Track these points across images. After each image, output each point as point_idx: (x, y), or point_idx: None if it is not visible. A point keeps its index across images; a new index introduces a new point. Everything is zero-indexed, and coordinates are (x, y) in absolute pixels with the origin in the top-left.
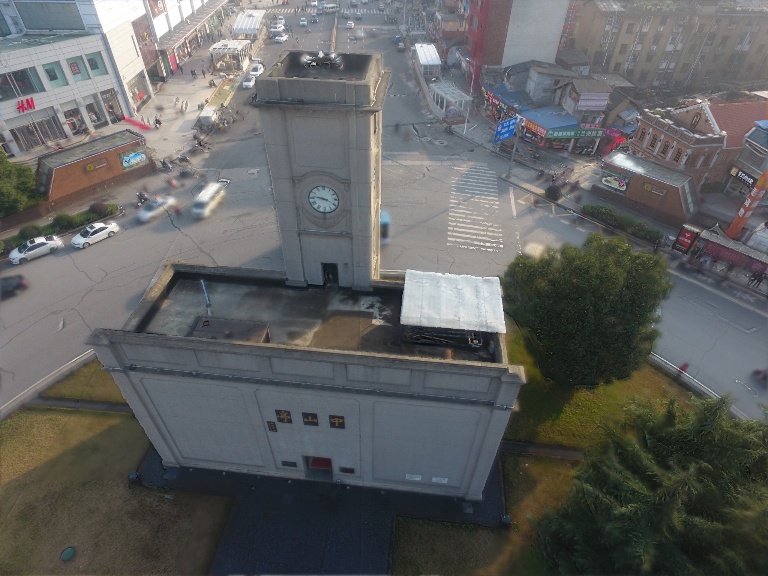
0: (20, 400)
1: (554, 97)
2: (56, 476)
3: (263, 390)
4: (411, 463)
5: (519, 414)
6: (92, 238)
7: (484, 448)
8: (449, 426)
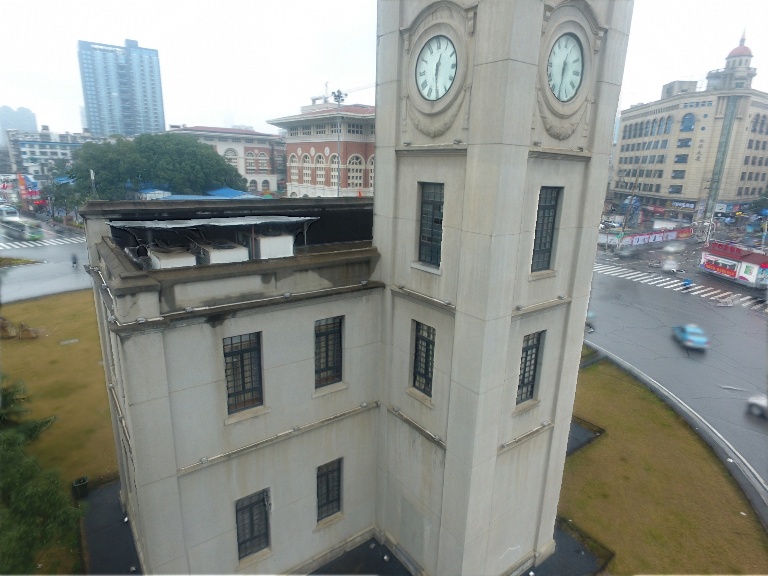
0: None
1: None
2: None
3: None
4: None
5: None
6: None
7: None
8: None
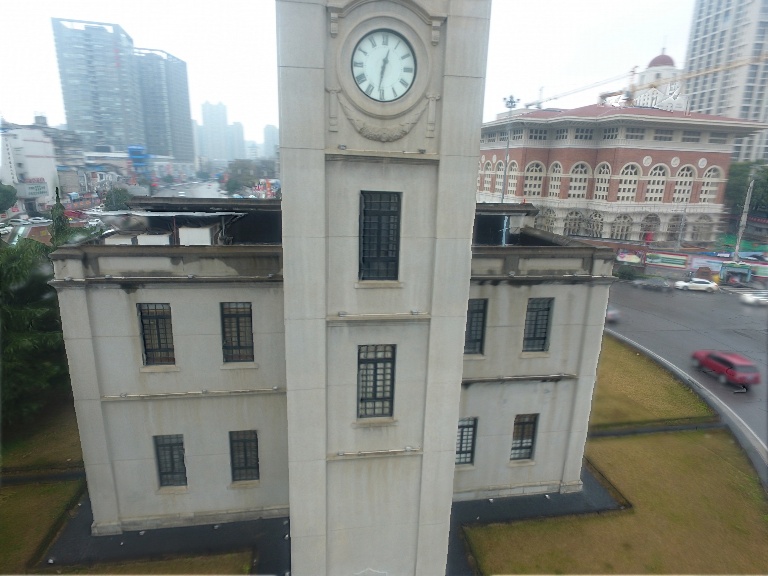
0: None
1: None
2: None
3: None
4: None
5: (21, 517)
6: None
7: None
8: None
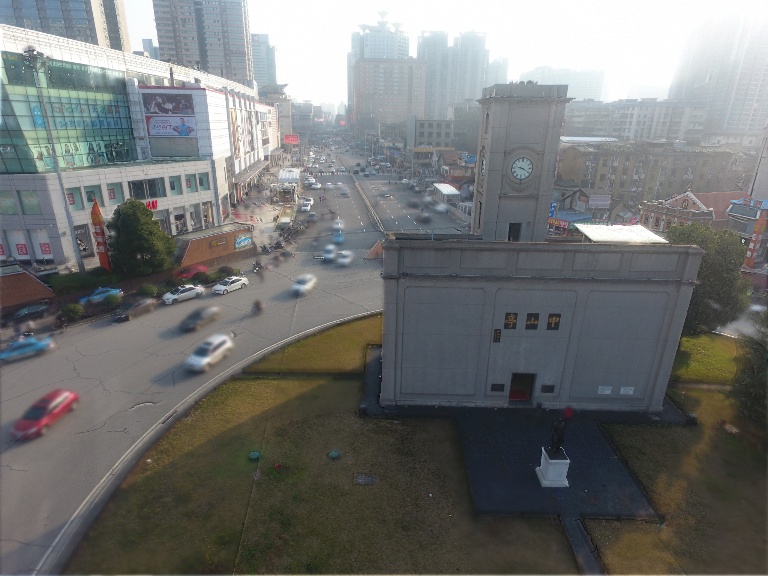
0: (226, 375)
1: (564, 205)
2: (292, 412)
3: (503, 289)
4: (606, 370)
5: None
6: (231, 286)
7: (670, 336)
8: (643, 315)
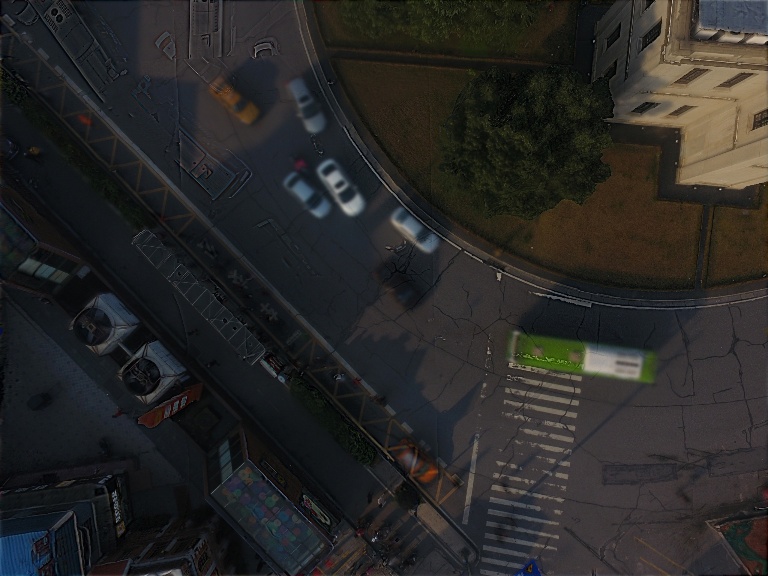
0: None
1: None
2: None
3: None
4: None
5: None
6: None
7: None
8: None
